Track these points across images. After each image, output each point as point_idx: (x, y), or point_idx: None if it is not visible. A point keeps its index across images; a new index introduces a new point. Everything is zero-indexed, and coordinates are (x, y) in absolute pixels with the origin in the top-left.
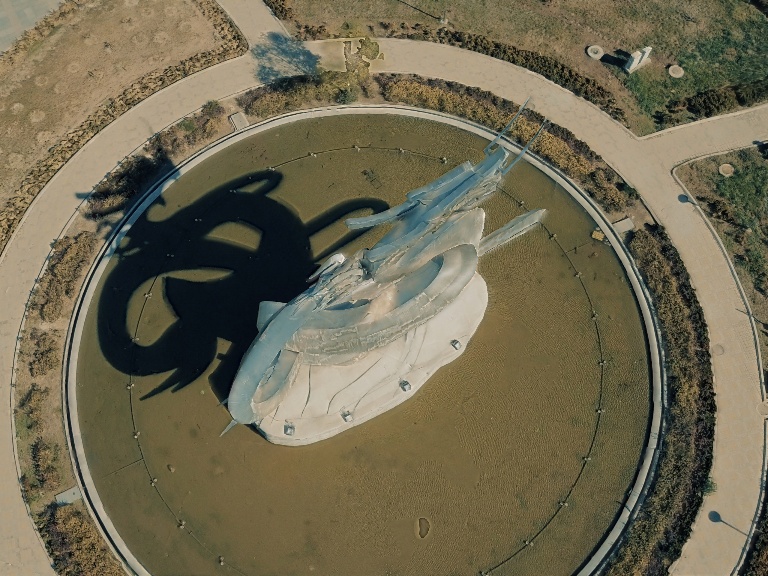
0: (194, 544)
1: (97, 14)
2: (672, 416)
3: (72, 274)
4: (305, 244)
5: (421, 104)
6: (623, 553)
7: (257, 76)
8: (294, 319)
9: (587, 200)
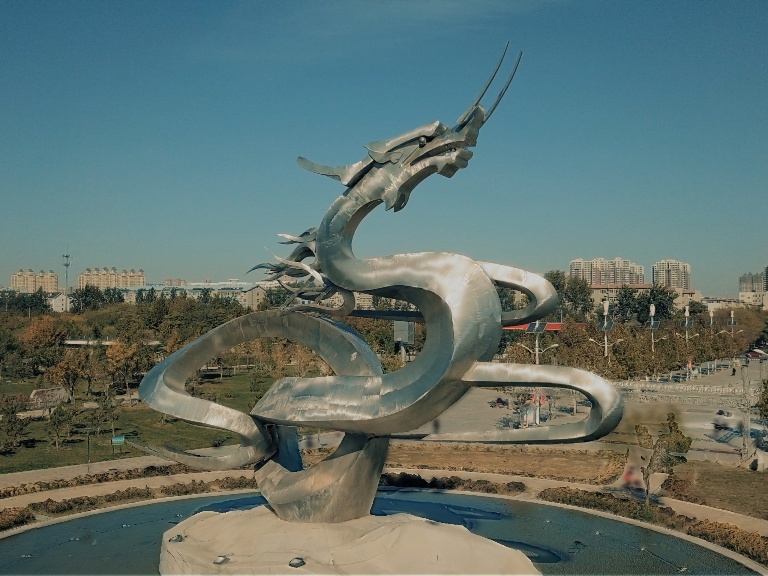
0: (3, 565)
1: (526, 455)
2: None
3: None
4: None
5: (722, 542)
6: None
7: None
8: None
9: None
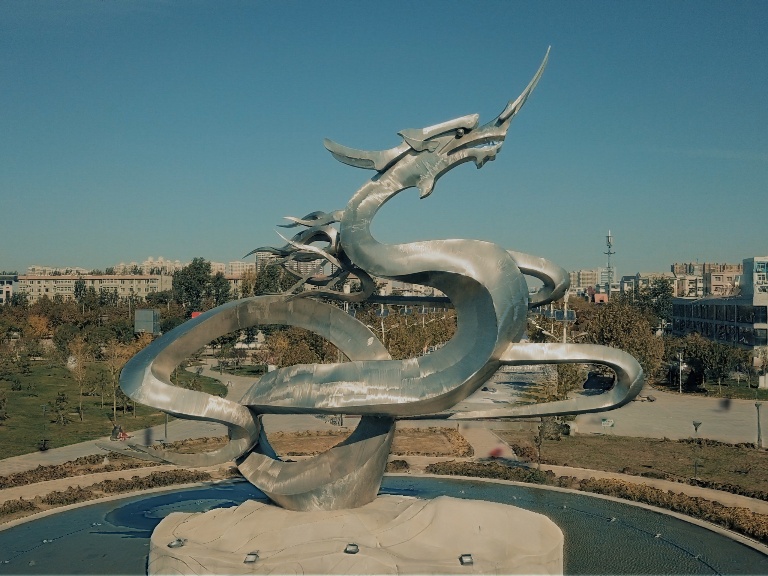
0: None
1: None
2: None
3: (162, 480)
4: None
5: (618, 494)
6: None
7: None
8: None
9: None
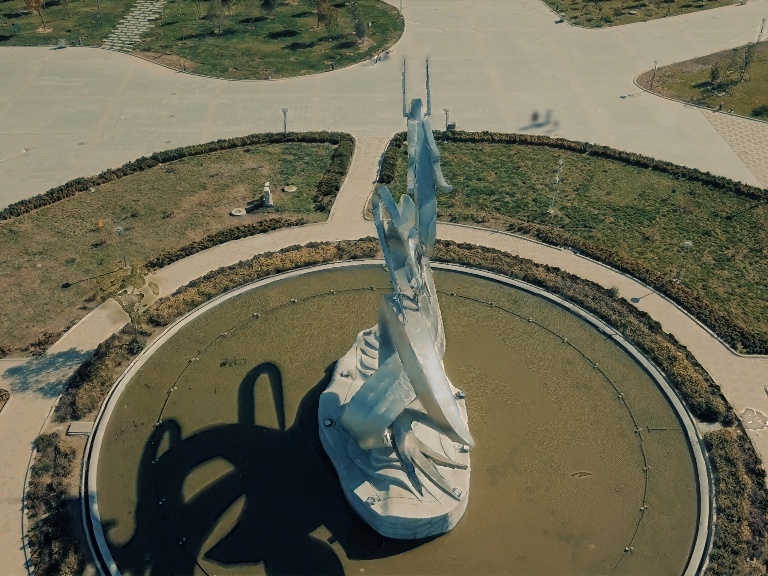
0: None
1: None
2: (554, 287)
3: None
4: (260, 430)
5: (192, 306)
6: (649, 347)
7: (45, 397)
8: (419, 330)
9: (357, 261)
